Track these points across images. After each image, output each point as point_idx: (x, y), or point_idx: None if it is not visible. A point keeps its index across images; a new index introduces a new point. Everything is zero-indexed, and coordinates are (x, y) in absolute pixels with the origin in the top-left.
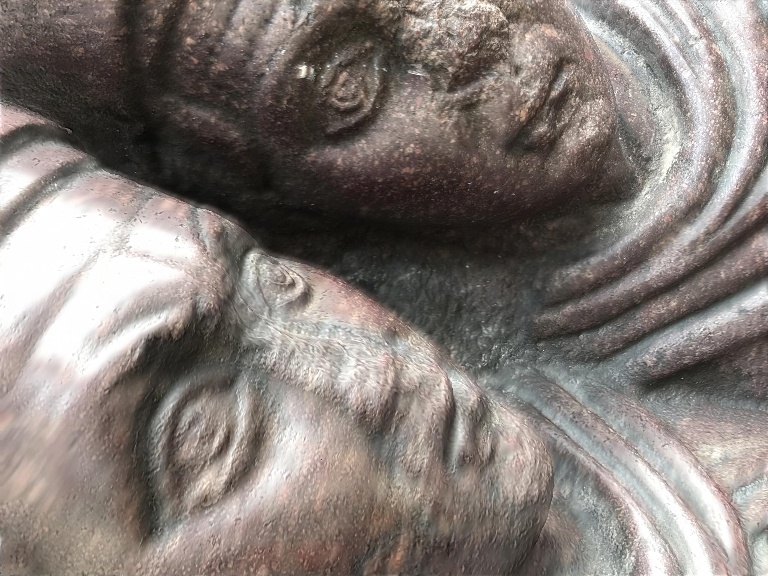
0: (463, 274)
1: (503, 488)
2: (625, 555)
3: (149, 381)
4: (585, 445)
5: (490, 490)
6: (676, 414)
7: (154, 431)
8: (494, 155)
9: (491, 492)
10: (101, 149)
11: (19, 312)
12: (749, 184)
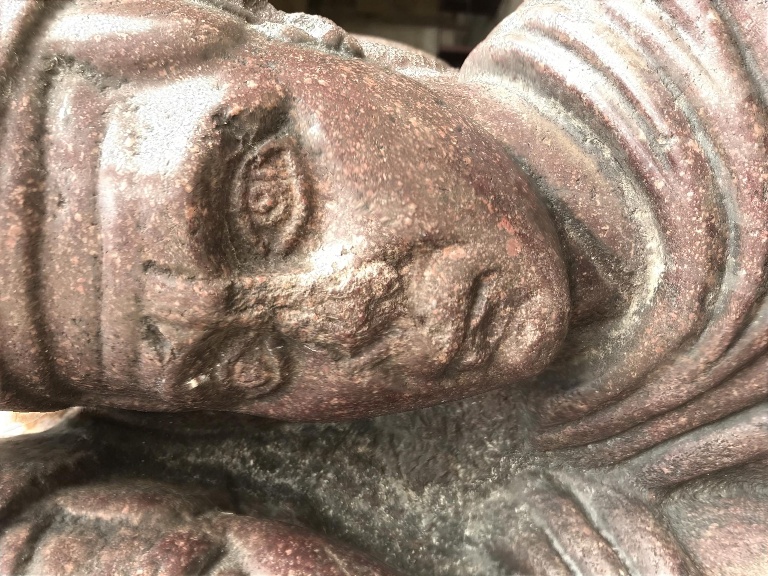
0: None
1: None
2: None
3: None
4: None
5: None
6: (702, 519)
7: None
8: (426, 386)
9: None
10: None
11: None
12: (751, 310)
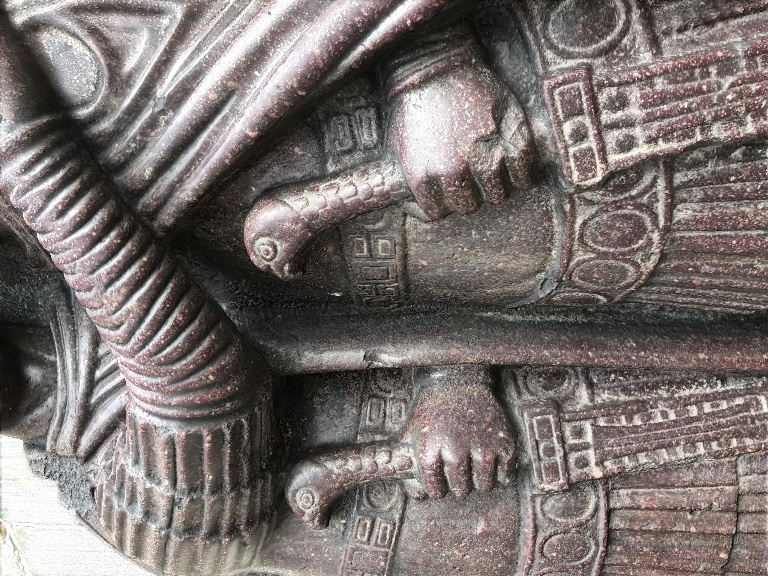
0: (6, 250)
1: None
2: None
3: None
4: None
5: None
6: None
7: None
8: None
9: None
10: None
11: None
12: None
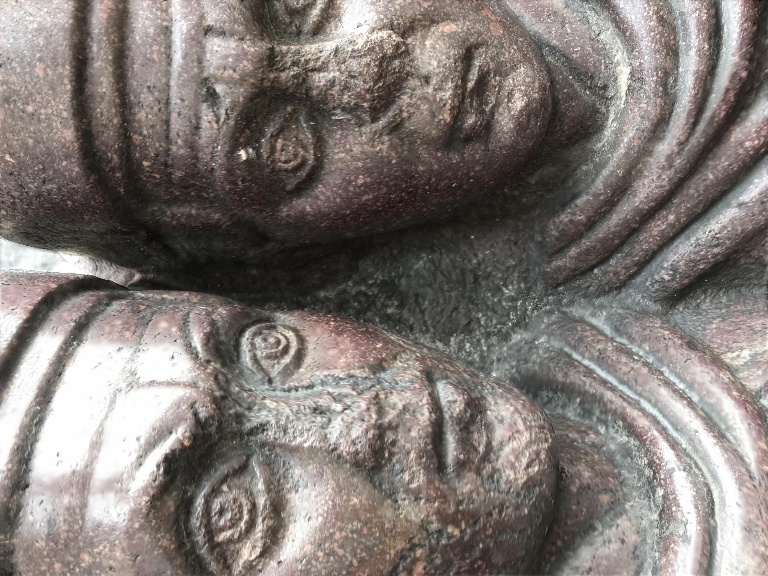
0: (470, 246)
1: (504, 468)
2: (656, 479)
3: (179, 483)
4: (613, 379)
5: (491, 474)
6: (706, 318)
7: (195, 518)
8: (437, 158)
9: (493, 475)
10: (125, 255)
11: (72, 462)
12: (707, 84)
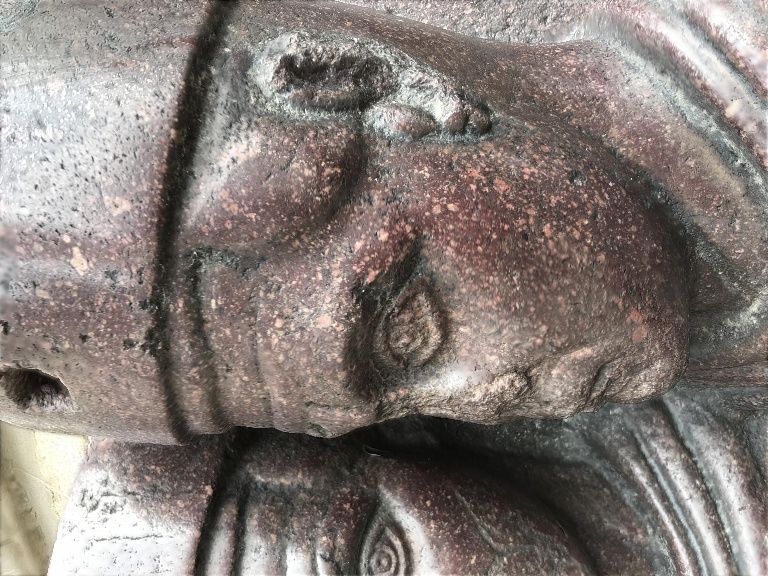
0: None
1: None
2: None
3: None
4: (671, 495)
5: None
6: None
7: None
8: None
9: None
10: None
11: None
12: None
